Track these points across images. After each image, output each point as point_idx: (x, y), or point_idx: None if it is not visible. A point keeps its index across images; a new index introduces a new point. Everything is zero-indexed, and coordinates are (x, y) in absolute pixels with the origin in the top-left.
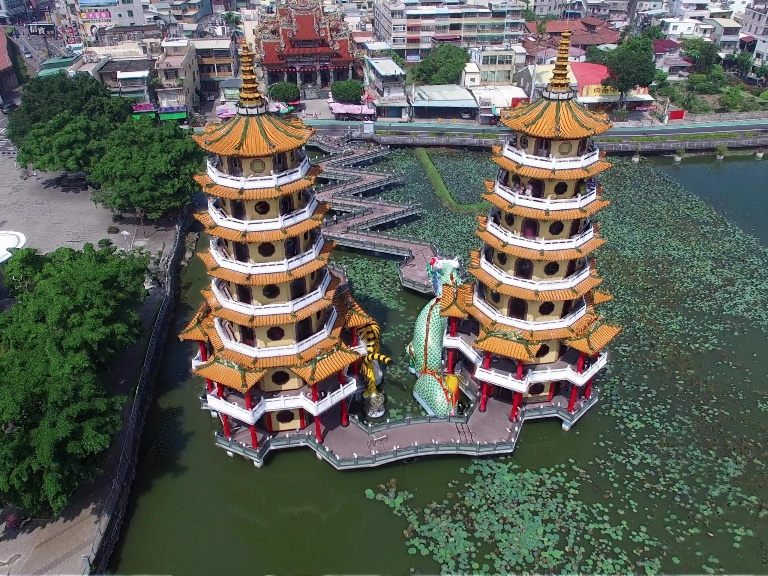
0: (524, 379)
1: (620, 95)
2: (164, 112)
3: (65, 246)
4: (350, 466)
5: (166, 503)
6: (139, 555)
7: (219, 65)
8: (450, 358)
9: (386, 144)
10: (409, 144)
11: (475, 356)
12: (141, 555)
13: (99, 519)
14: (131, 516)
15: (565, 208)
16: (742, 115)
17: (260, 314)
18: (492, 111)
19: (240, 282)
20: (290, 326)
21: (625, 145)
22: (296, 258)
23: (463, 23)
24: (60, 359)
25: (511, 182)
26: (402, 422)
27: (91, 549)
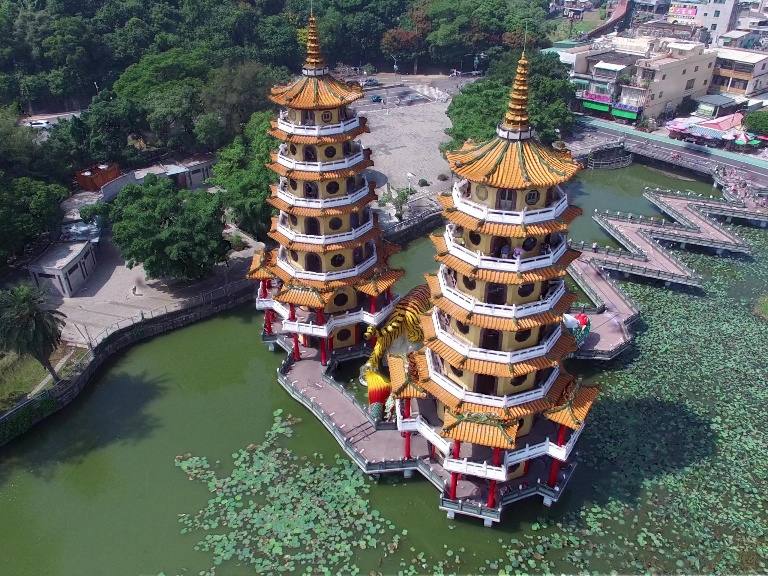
0: (405, 418)
1: None
2: (617, 108)
3: (405, 174)
4: (283, 384)
5: (221, 330)
6: (180, 341)
7: (736, 80)
8: None
9: None
10: None
11: None
12: (180, 341)
13: (172, 303)
14: (201, 322)
15: (464, 259)
16: None
17: (280, 231)
18: None
19: None
20: (300, 254)
21: None
22: (304, 199)
23: None
24: None
25: None
26: (339, 387)
27: (150, 311)
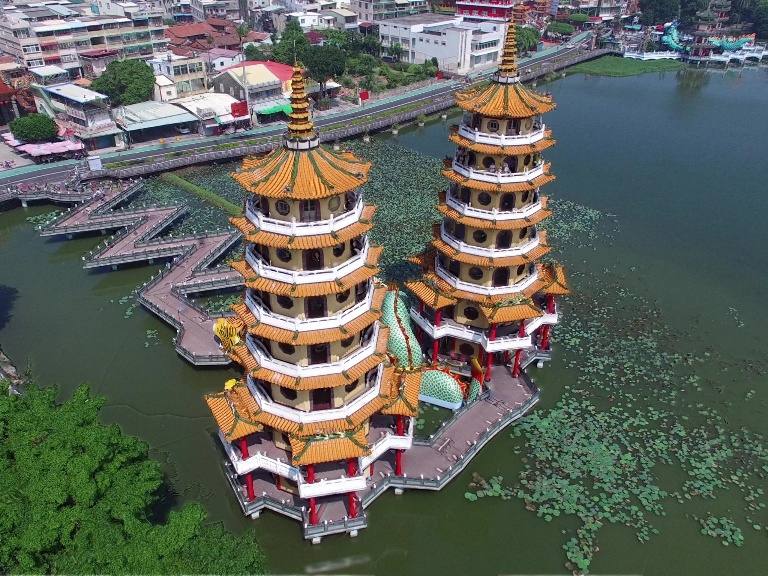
0: (527, 335)
1: (320, 86)
2: None
3: None
4: (446, 481)
5: None
6: None
7: None
8: (436, 348)
9: (127, 177)
10: (153, 172)
11: (472, 334)
12: None
13: None
14: None
15: (536, 176)
16: (408, 88)
17: (349, 367)
18: (216, 121)
19: (337, 338)
20: None
21: (354, 129)
22: None
23: (105, 36)
24: (164, 529)
25: (482, 165)
26: (452, 420)
27: None
